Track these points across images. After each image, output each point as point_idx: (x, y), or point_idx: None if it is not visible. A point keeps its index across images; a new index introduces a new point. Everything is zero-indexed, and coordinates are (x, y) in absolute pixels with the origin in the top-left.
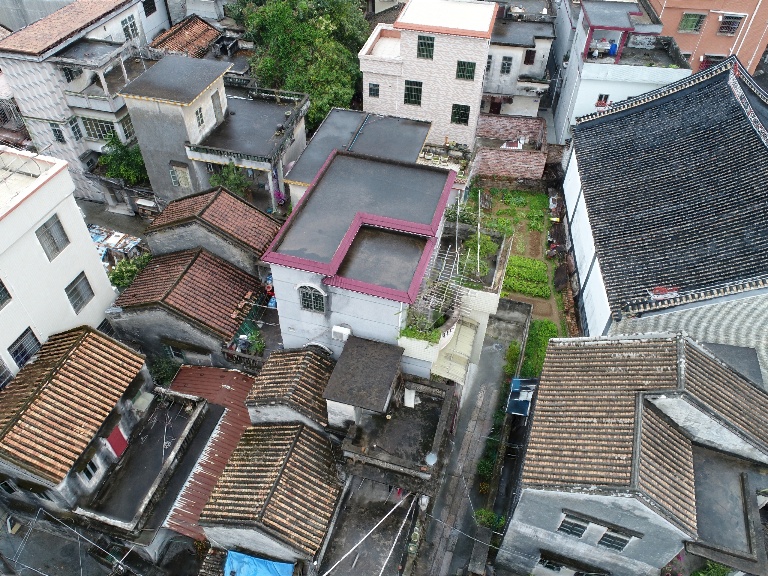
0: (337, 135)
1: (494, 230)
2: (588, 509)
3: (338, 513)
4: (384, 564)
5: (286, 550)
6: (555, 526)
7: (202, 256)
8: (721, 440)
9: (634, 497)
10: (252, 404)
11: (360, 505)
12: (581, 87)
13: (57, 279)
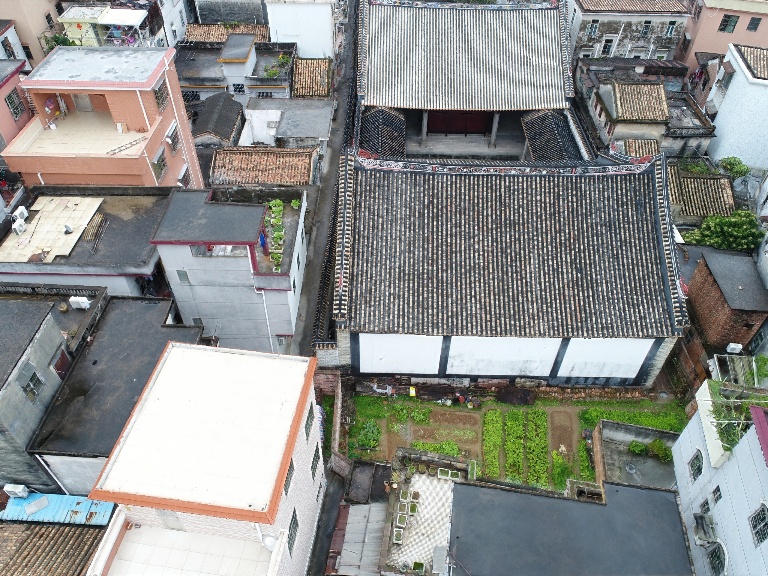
0: None
1: None
2: None
3: None
4: None
5: None
6: None
7: None
8: None
9: None
10: None
11: None
12: (288, 297)
13: None
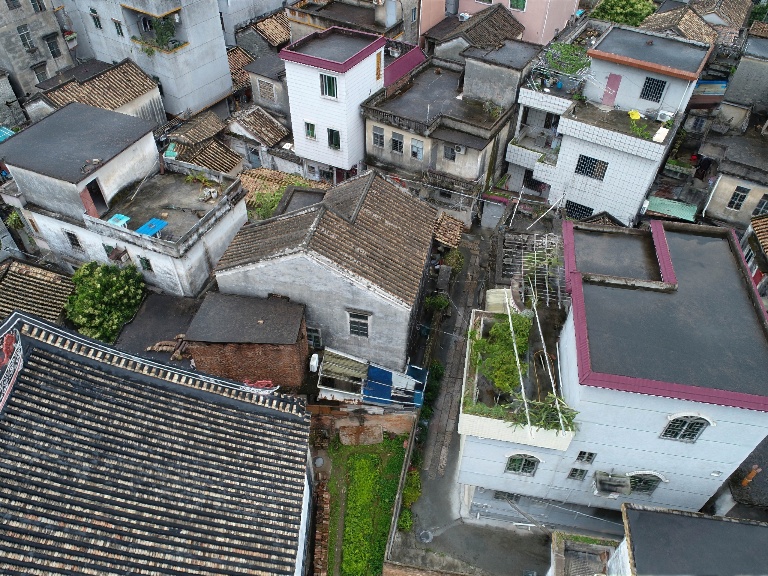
0: None
1: None
2: None
3: None
4: None
5: None
6: None
7: None
8: None
9: None
10: None
11: None
12: None
13: None
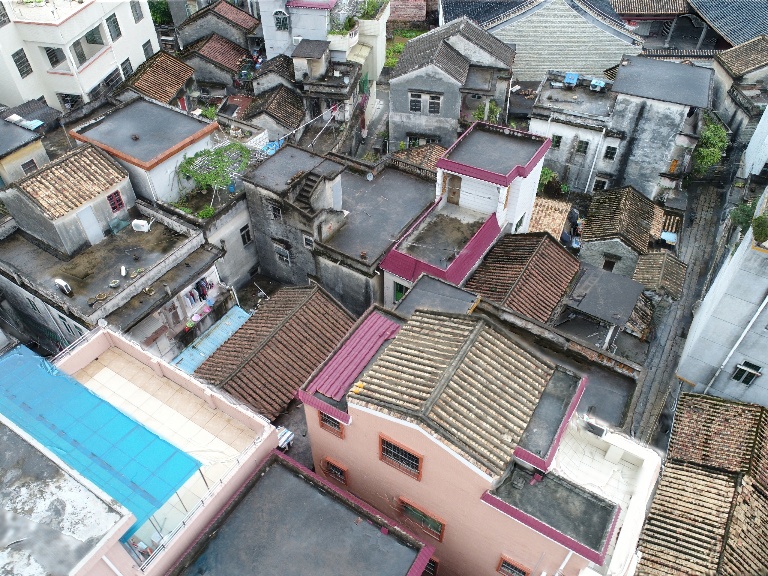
0: None
1: (378, 1)
2: (418, 84)
3: (304, 129)
4: (327, 123)
5: (280, 129)
6: (408, 107)
7: (215, 37)
8: (482, 59)
9: (432, 63)
10: (255, 77)
11: (316, 128)
12: None
13: (139, 37)
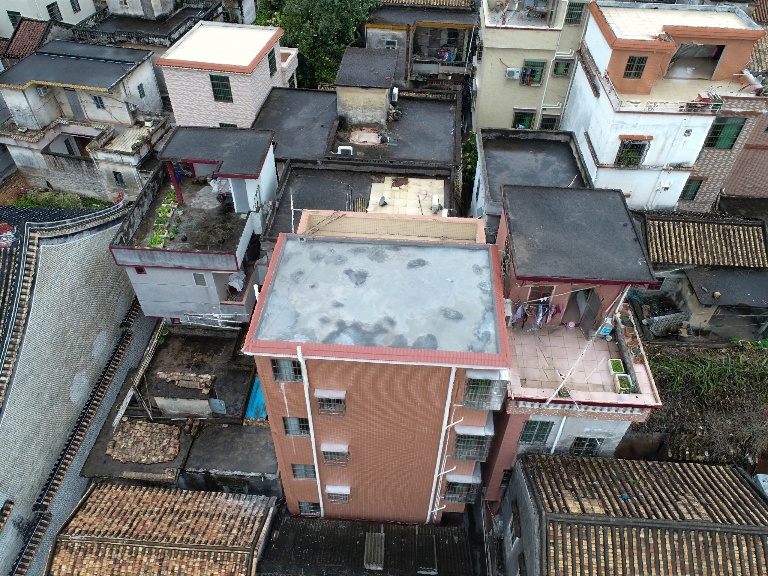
0: (106, 54)
1: None
2: None
3: None
4: None
5: None
6: None
7: None
8: None
9: None
10: None
11: None
12: None
13: (1, 1)
